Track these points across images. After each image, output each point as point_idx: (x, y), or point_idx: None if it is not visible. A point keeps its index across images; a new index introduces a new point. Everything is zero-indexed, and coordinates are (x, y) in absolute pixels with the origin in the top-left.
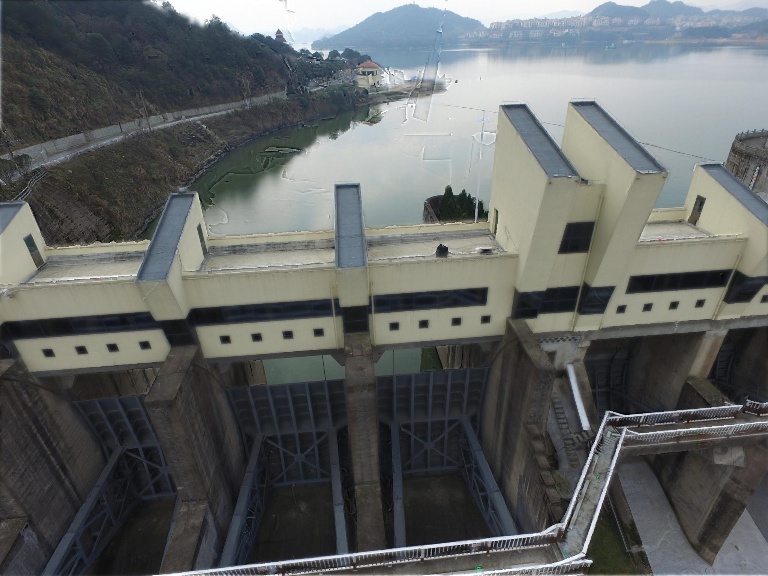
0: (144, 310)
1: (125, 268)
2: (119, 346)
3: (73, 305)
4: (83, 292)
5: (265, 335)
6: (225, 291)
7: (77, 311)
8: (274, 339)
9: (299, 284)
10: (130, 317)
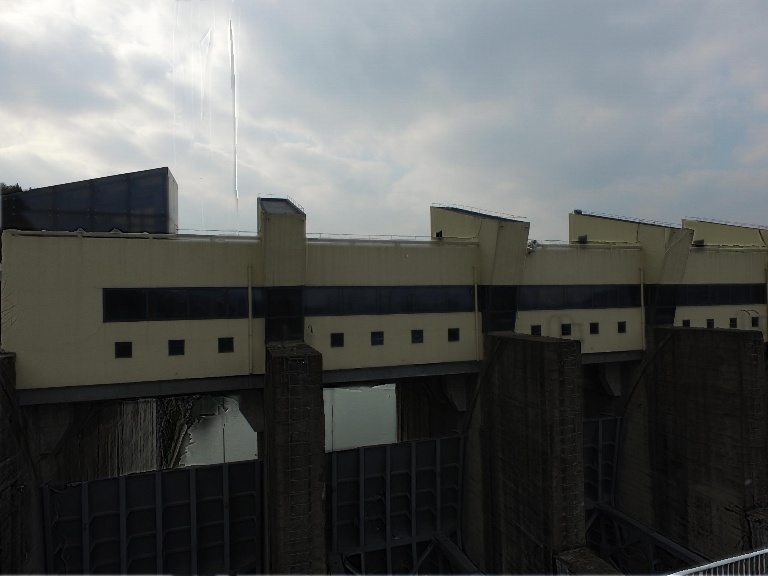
0: (629, 282)
1: None
2: (600, 326)
3: (573, 270)
4: (586, 255)
5: (716, 322)
6: (692, 267)
7: (575, 278)
8: (722, 327)
9: (744, 265)
10: (612, 292)
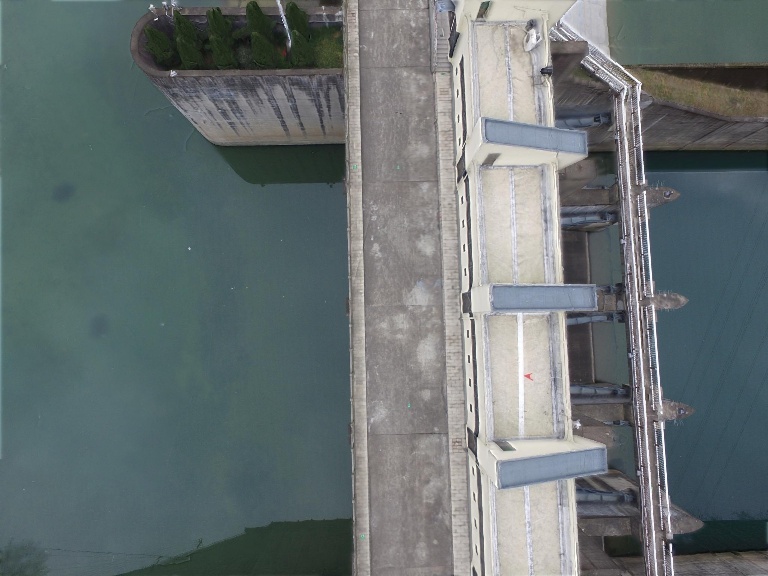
0: None
1: (505, 360)
2: None
3: None
4: None
5: None
6: None
7: None
8: None
9: None
10: None
